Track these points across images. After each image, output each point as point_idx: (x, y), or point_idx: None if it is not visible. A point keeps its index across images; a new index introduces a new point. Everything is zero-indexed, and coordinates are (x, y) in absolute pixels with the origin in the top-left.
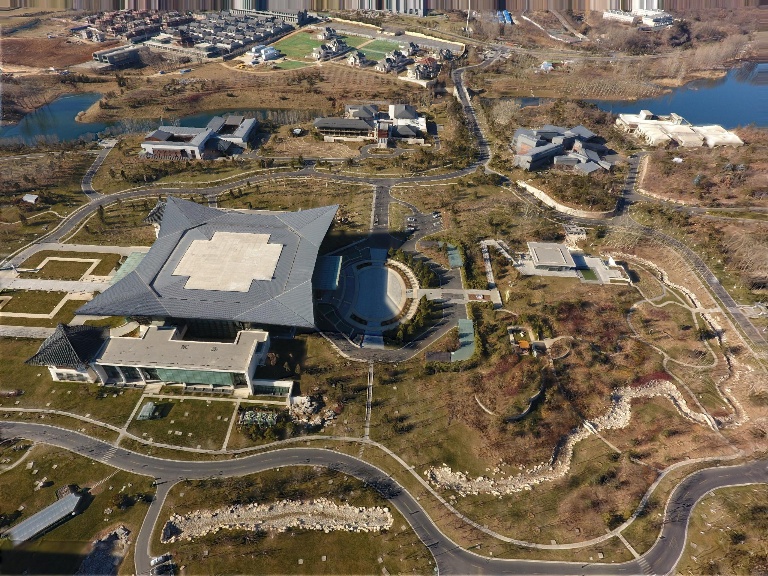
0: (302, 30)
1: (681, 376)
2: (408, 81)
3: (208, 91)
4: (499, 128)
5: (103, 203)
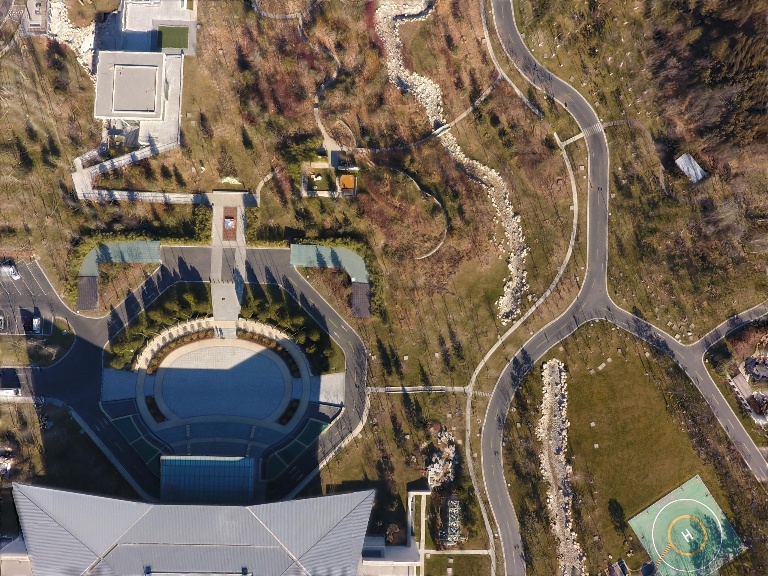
0: None
1: None
2: None
3: None
4: None
5: None
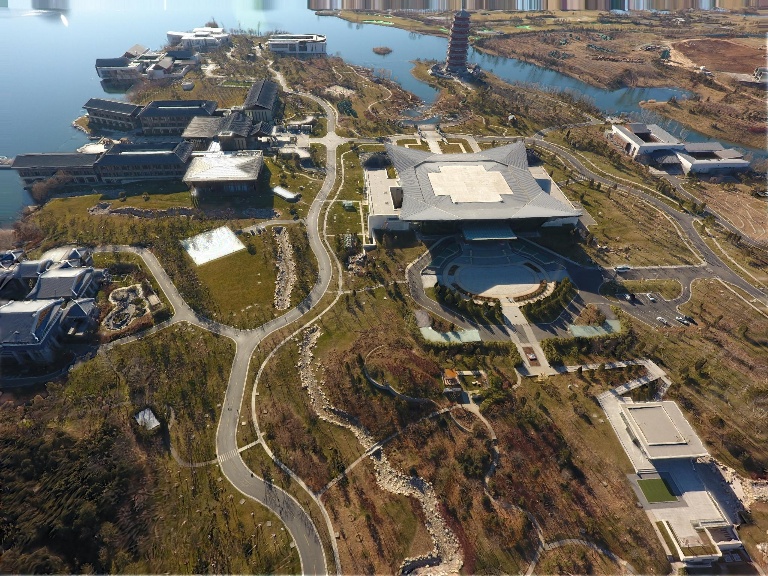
0: None
1: None
2: None
3: None
4: None
5: (532, 142)
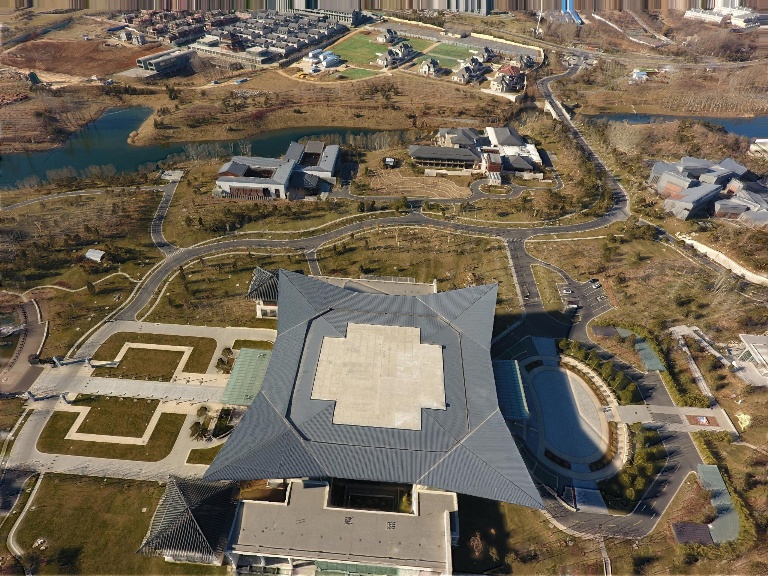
0: (358, 31)
1: None
2: (493, 94)
3: (272, 107)
4: (624, 158)
5: (181, 260)
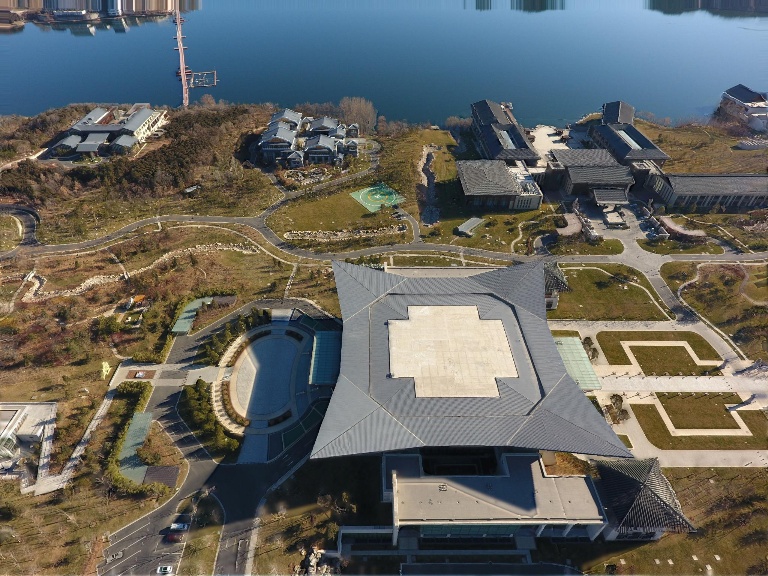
0: None
1: (5, 306)
2: None
3: None
4: None
5: None
